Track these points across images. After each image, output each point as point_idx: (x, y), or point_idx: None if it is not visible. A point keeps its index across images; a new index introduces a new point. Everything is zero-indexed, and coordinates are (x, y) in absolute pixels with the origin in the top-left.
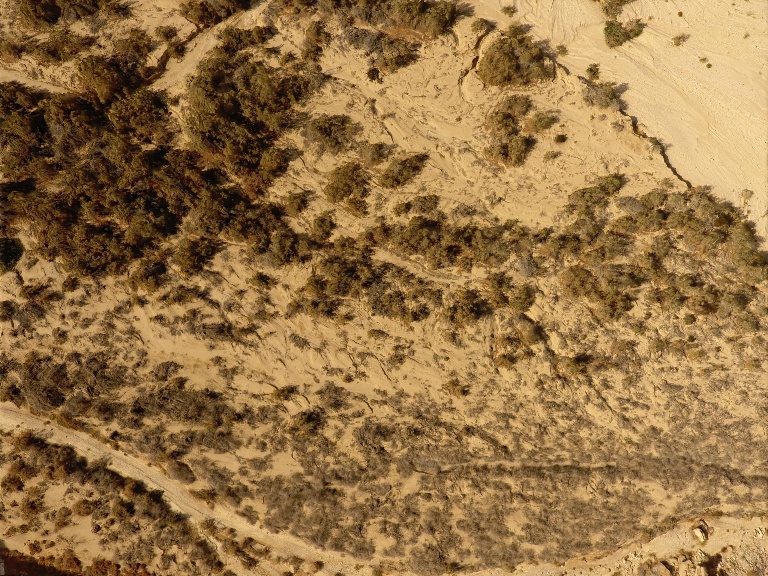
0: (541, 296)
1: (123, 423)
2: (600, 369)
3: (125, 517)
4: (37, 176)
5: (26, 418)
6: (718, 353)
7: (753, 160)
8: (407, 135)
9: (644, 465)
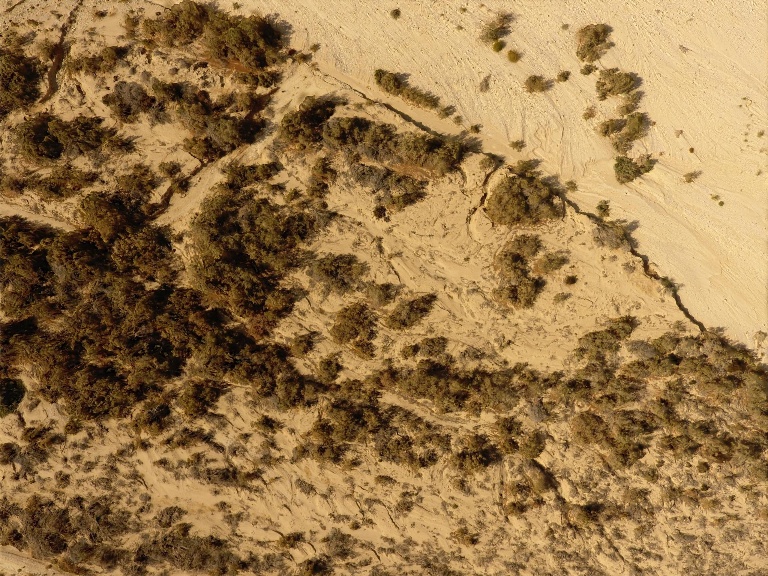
0: (551, 443)
1: (126, 571)
2: (612, 518)
3: None
4: (39, 315)
5: (28, 562)
6: (732, 502)
7: (767, 301)
8: (414, 275)
9: None
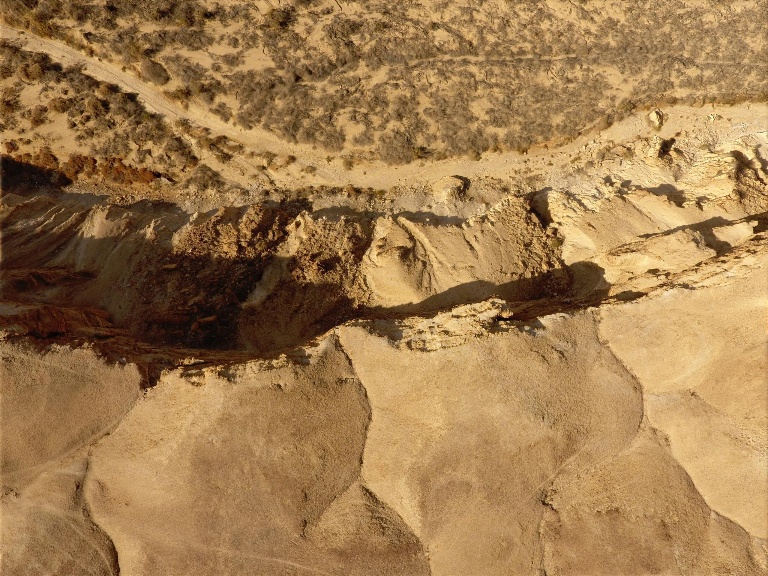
0: None
1: (97, 23)
2: None
3: (100, 112)
4: None
5: (0, 28)
6: None
7: None
8: None
9: (602, 54)
